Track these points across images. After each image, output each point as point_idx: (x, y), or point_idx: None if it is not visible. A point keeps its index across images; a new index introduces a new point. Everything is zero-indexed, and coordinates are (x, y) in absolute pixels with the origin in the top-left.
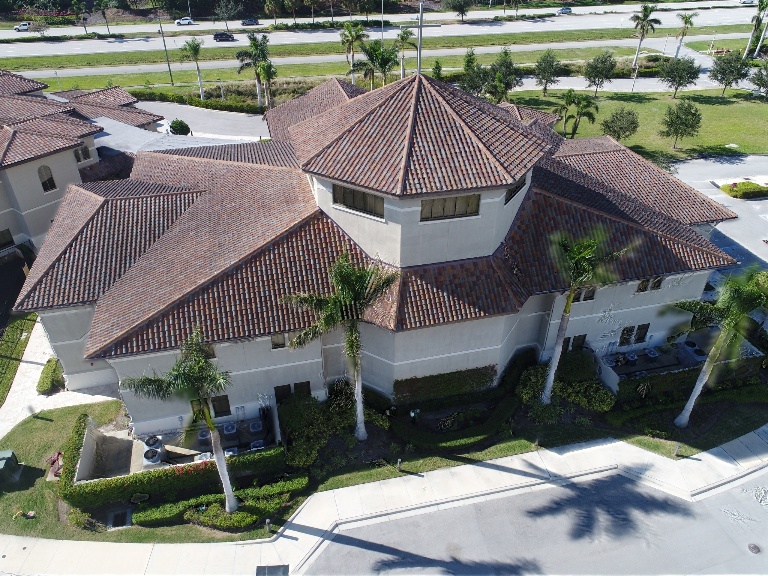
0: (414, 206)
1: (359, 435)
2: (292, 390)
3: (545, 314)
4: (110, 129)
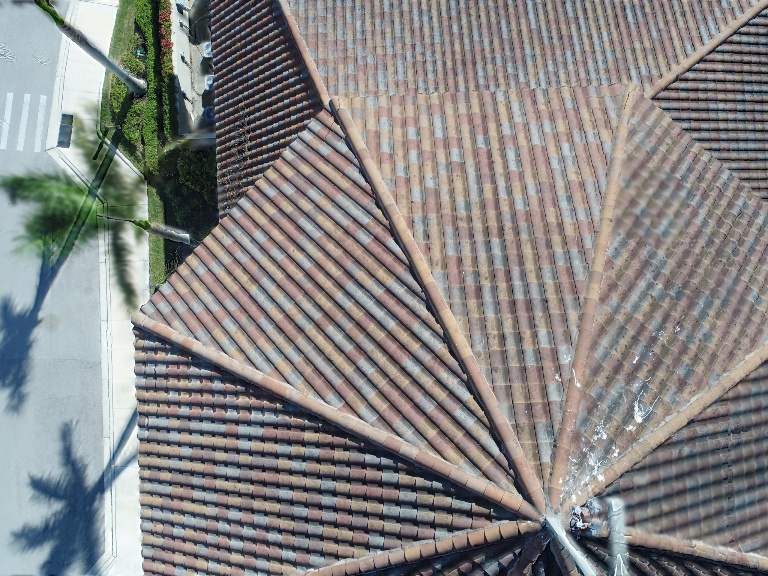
0: None
1: None
2: None
3: None
4: None
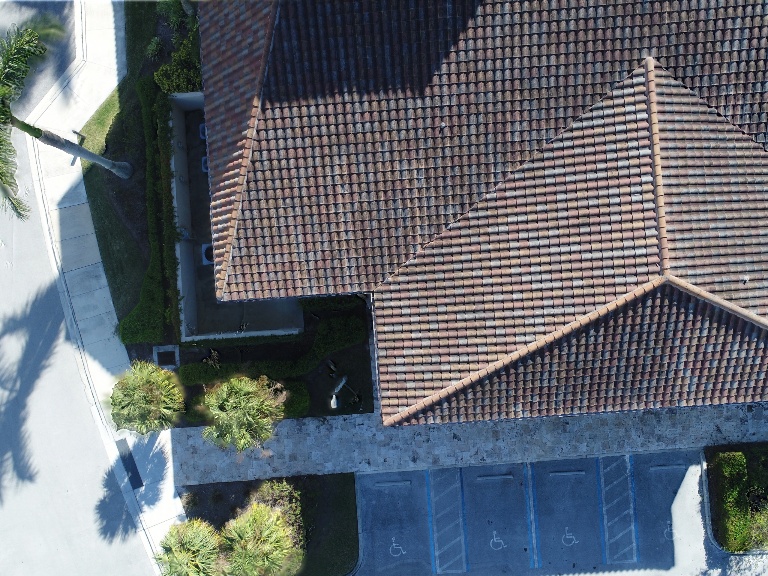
0: None
1: None
2: None
3: None
4: None
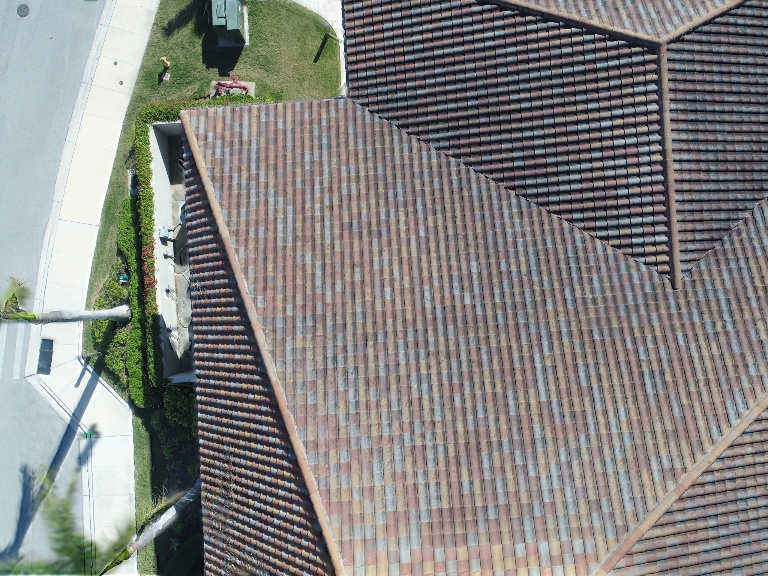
0: None
1: None
2: None
3: None
4: None
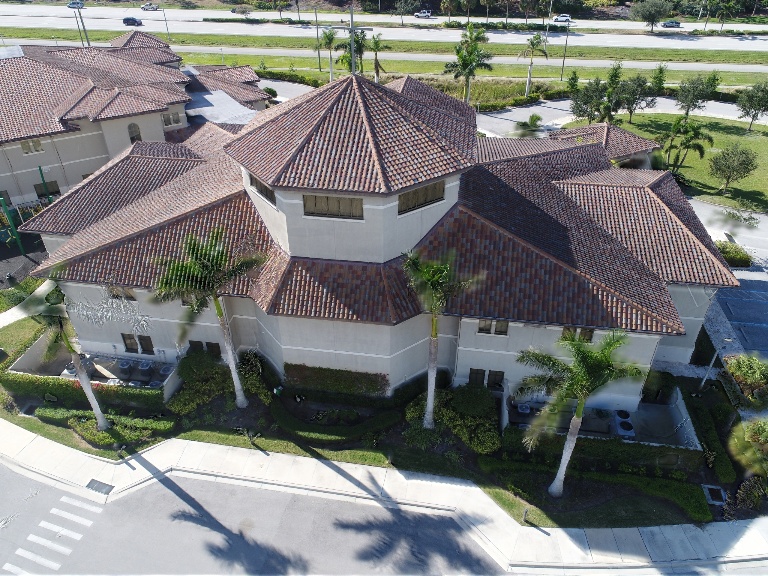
0: (297, 199)
1: (237, 402)
2: (205, 348)
3: (453, 338)
4: (217, 101)
